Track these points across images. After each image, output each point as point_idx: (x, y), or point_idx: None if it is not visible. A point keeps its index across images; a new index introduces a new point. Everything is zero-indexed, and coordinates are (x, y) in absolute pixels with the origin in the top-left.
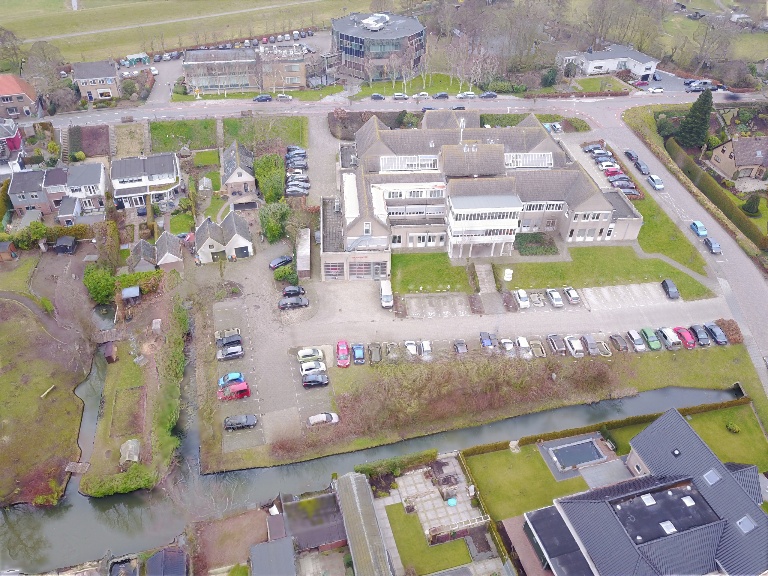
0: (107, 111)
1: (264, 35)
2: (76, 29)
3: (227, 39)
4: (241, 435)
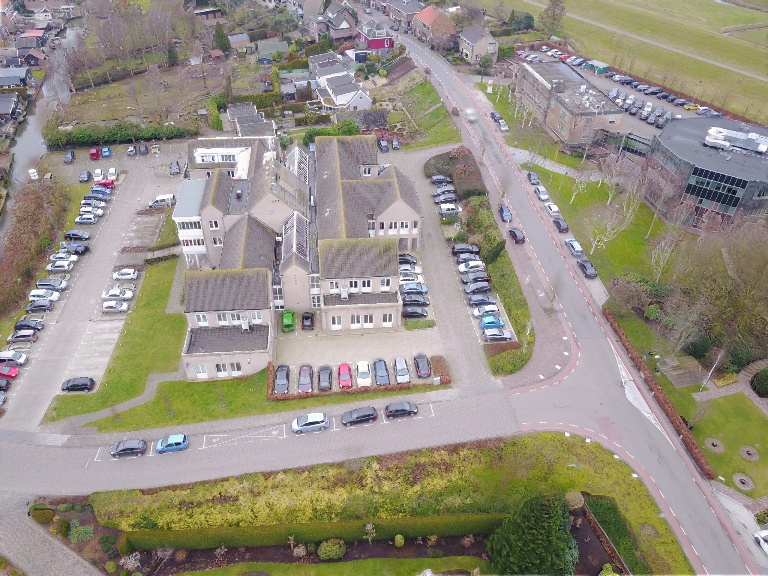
0: (446, 64)
1: (740, 116)
2: (646, 34)
3: (694, 96)
4: (61, 160)
